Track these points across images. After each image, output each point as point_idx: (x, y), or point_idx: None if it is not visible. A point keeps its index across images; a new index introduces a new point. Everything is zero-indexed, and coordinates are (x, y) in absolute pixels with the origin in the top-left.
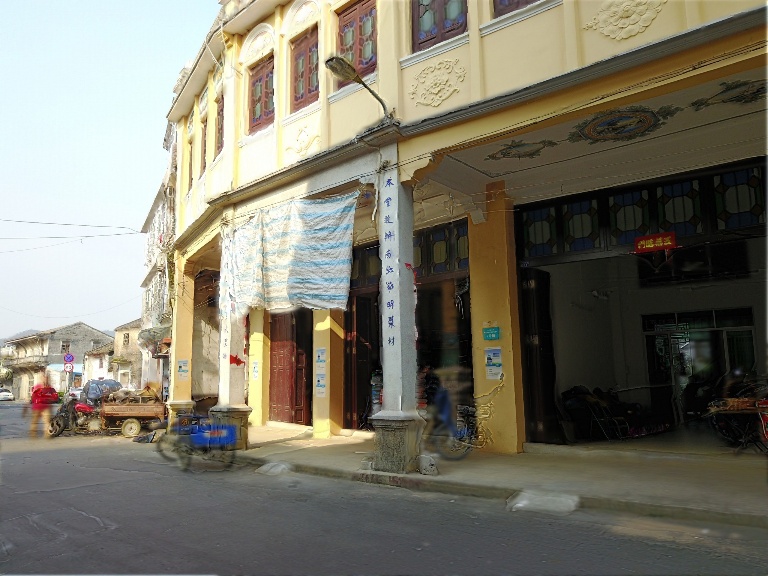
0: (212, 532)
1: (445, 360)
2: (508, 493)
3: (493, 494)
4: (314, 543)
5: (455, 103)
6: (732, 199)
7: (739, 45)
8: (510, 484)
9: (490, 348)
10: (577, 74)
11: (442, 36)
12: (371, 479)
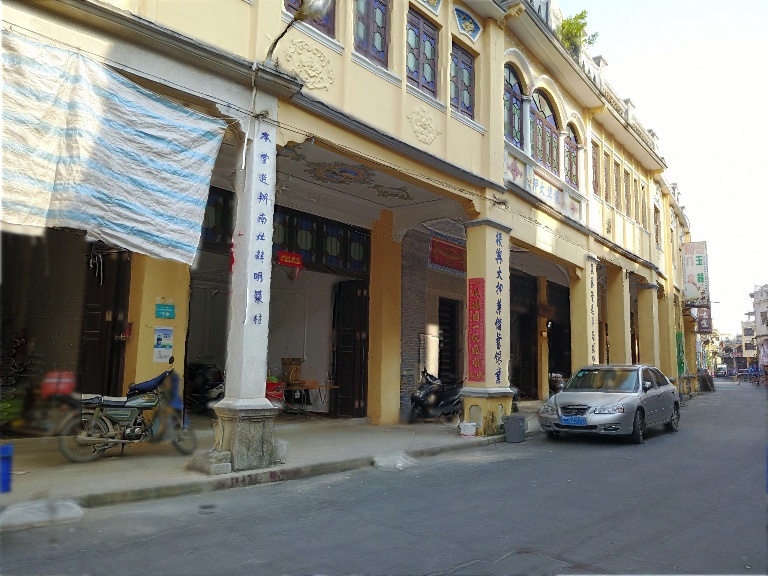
0: (521, 519)
1: (58, 334)
2: (368, 461)
3: (357, 465)
4: (541, 498)
5: (326, 99)
6: (329, 245)
7: (462, 187)
8: (342, 456)
9: (160, 327)
10: (415, 151)
11: (311, 20)
12: (249, 481)
